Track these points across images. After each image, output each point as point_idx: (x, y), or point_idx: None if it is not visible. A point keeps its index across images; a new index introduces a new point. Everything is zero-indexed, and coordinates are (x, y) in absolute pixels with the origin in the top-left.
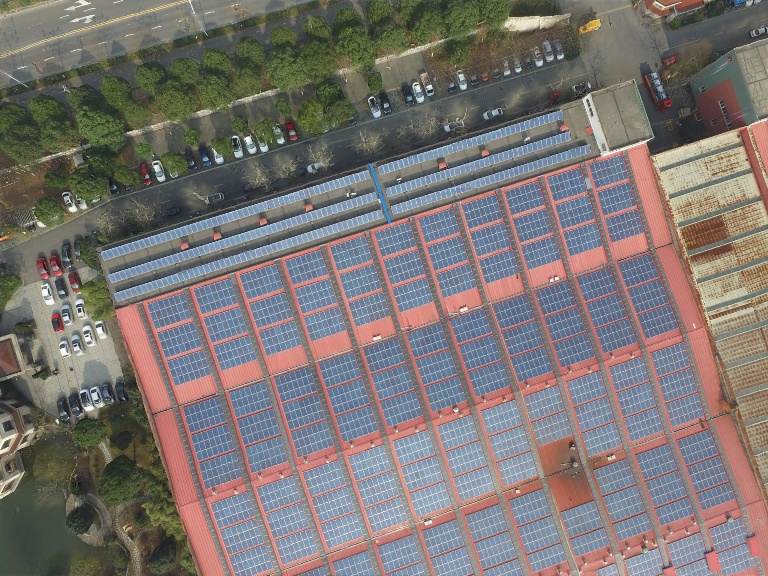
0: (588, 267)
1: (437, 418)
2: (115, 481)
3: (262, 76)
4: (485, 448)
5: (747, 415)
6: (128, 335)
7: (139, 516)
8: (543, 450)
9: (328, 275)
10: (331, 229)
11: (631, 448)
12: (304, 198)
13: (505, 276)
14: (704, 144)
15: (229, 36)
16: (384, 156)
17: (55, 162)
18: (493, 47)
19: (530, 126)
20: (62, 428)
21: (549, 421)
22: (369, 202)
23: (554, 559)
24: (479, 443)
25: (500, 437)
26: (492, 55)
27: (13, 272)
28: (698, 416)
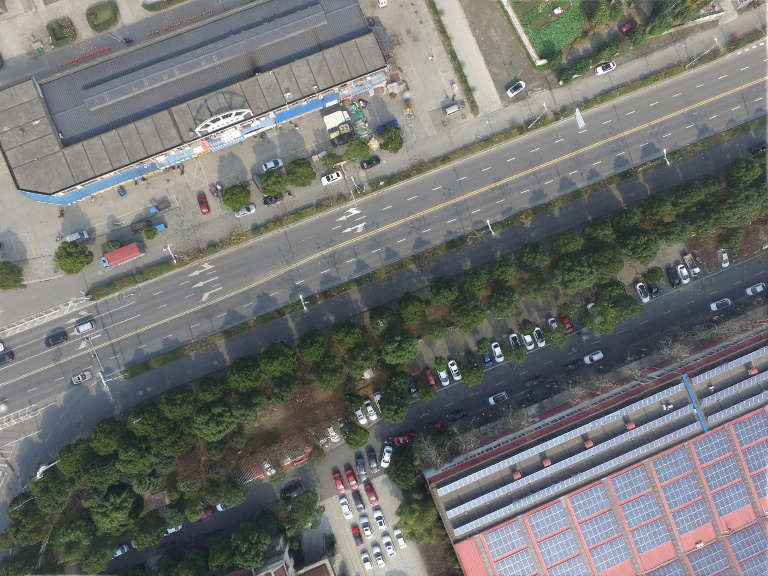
0: None
1: None
2: None
3: (550, 282)
4: None
5: None
6: (467, 567)
7: None
8: None
9: (651, 488)
10: (653, 444)
11: None
12: (623, 415)
13: None
14: None
15: (497, 233)
16: None
17: None
18: (762, 230)
19: None
20: None
21: None
22: (686, 413)
23: None
24: None
25: None
26: (761, 238)
27: (309, 489)
28: None
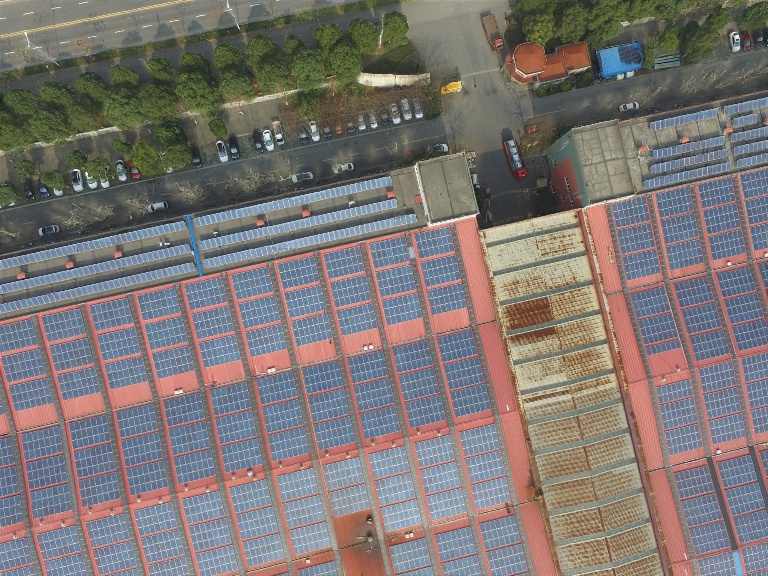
0: (405, 338)
1: (230, 480)
2: None
3: (100, 113)
4: (278, 514)
5: (555, 504)
6: None
7: None
8: (339, 521)
9: (133, 324)
10: (139, 278)
11: (431, 527)
12: (116, 244)
13: (317, 340)
14: (537, 222)
15: (82, 67)
16: (226, 202)
17: None
18: (343, 102)
19: (356, 190)
20: None
21: (347, 492)
22: (182, 253)
23: None
24: (272, 509)
25: (294, 504)
26: (342, 110)
27: None
28: (504, 500)
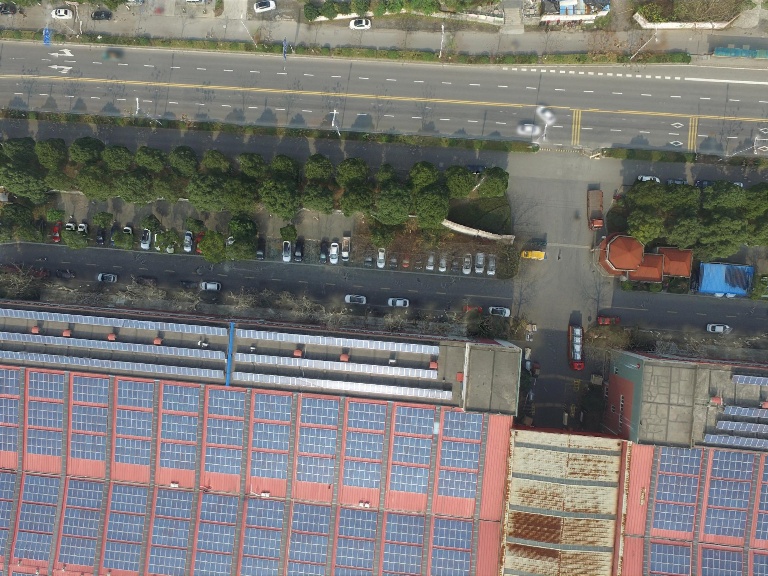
0: (404, 508)
1: None
2: None
3: (184, 189)
4: None
5: None
6: None
7: None
8: None
9: (152, 409)
10: (170, 369)
11: None
12: (159, 329)
13: (318, 481)
14: (575, 439)
15: (182, 131)
16: None
17: None
18: (418, 243)
19: (401, 349)
20: None
21: None
22: (216, 358)
23: None
24: None
25: None
26: (414, 250)
27: None
28: None
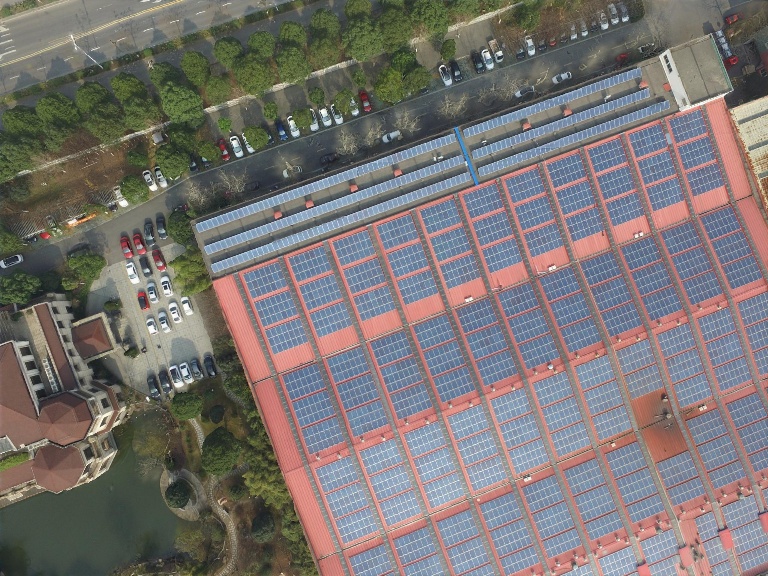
0: (671, 222)
1: (532, 375)
2: (219, 451)
3: (338, 47)
4: (580, 403)
5: None
6: (225, 306)
7: (236, 488)
8: (636, 403)
9: (419, 239)
10: (420, 193)
11: (721, 398)
12: (392, 164)
13: (591, 233)
14: None
15: (299, 10)
16: (458, 123)
17: (133, 141)
18: (562, 11)
19: (610, 84)
20: (153, 405)
21: (641, 374)
22: (456, 165)
23: (653, 509)
24: (574, 399)
25: (594, 392)
26: (561, 19)
27: (97, 252)
28: None
